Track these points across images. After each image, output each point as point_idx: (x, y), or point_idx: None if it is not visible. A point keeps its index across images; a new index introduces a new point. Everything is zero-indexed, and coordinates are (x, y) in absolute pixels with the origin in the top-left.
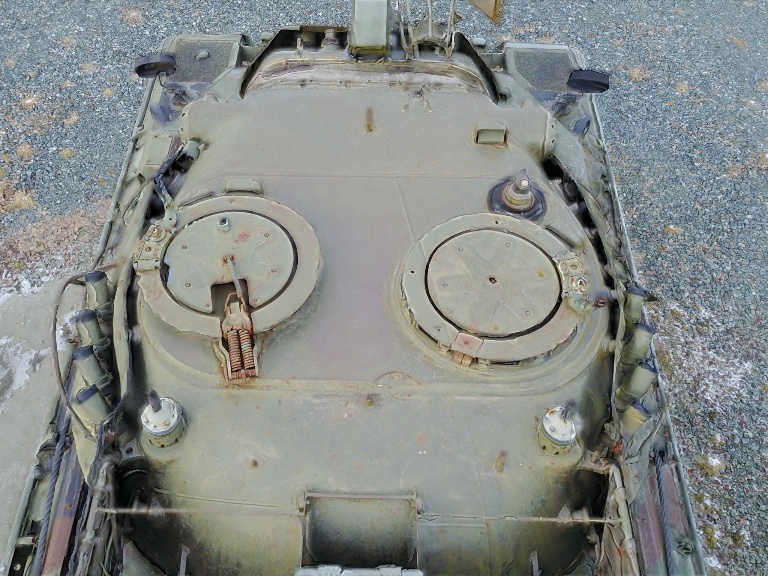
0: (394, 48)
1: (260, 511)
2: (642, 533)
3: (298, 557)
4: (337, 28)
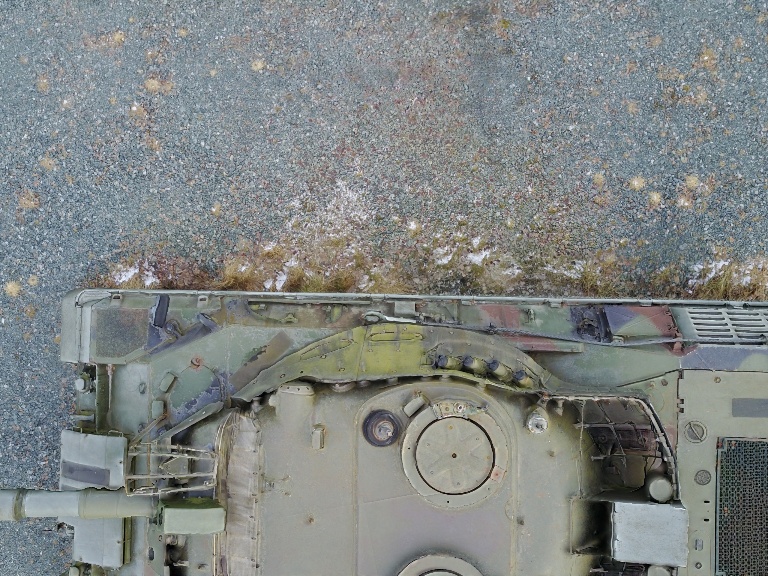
0: (204, 495)
1: (573, 573)
2: (540, 350)
3: (589, 550)
4: (166, 537)
